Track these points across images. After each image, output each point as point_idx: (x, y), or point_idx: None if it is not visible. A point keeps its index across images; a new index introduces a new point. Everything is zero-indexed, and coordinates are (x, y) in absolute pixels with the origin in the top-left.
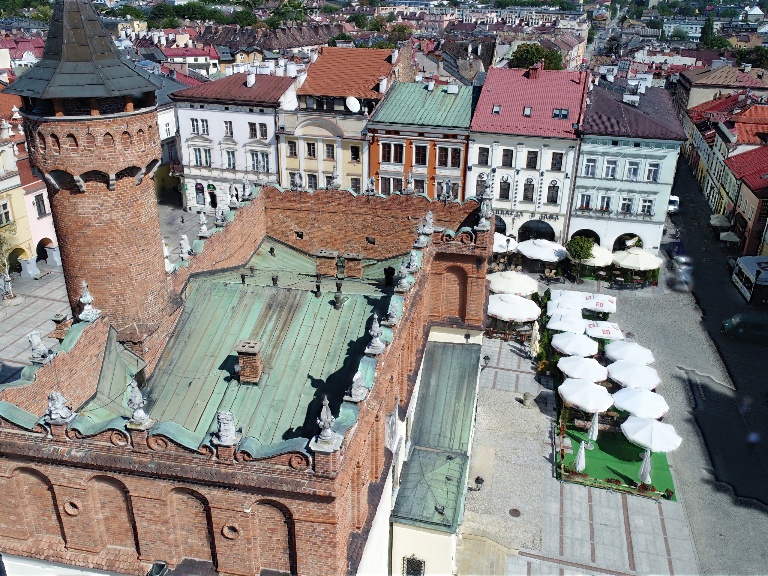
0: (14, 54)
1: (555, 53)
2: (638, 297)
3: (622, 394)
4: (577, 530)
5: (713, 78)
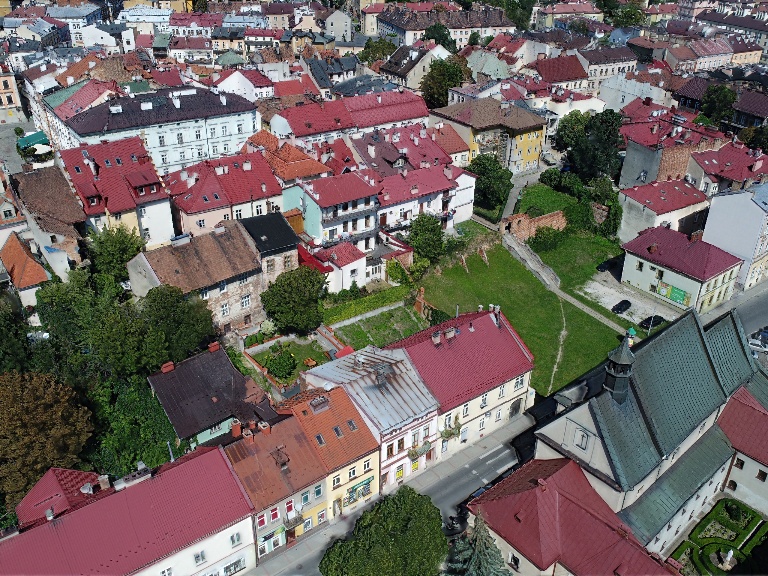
0: (188, 23)
1: (455, 67)
2: None
3: None
4: None
5: (447, 109)
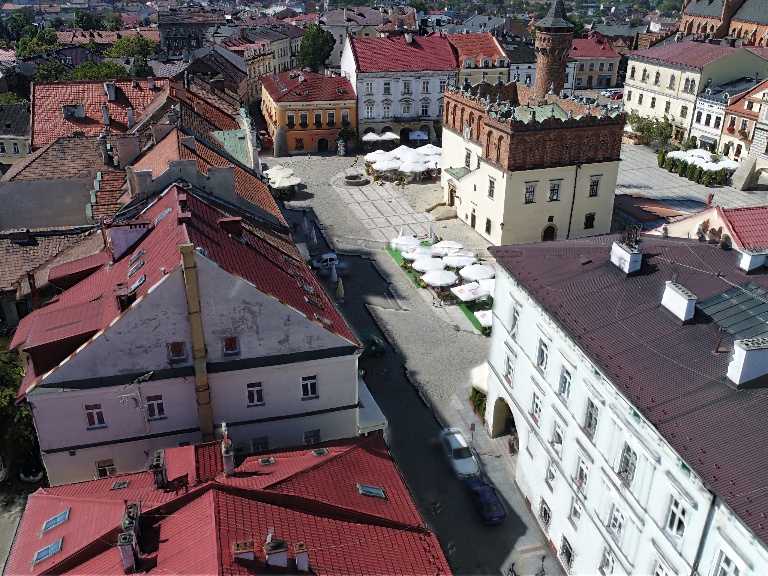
0: None
1: None
2: None
3: None
4: None
5: None
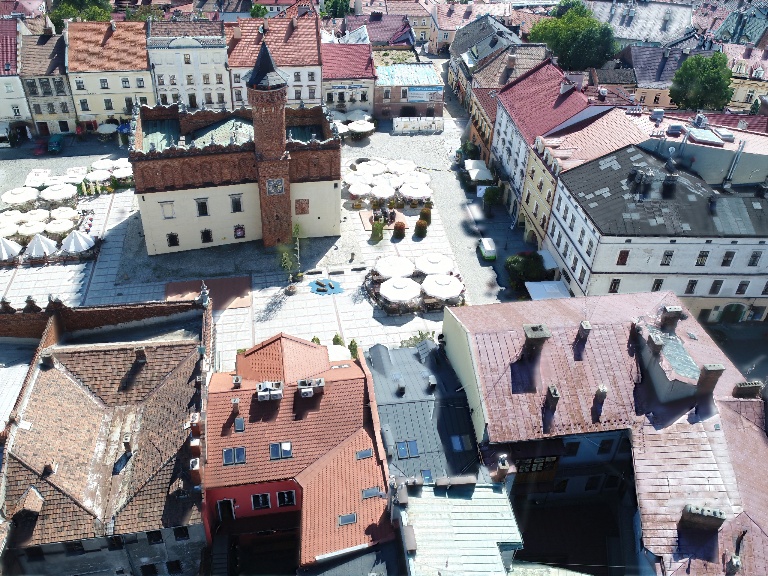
0: None
1: None
2: (6, 174)
3: None
4: None
5: None
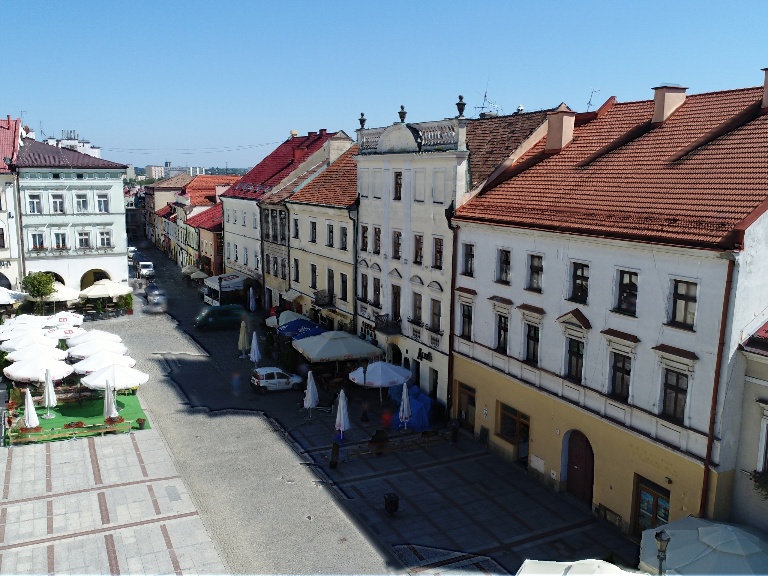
0: None
1: None
2: (113, 322)
3: (83, 361)
4: (28, 475)
5: None
